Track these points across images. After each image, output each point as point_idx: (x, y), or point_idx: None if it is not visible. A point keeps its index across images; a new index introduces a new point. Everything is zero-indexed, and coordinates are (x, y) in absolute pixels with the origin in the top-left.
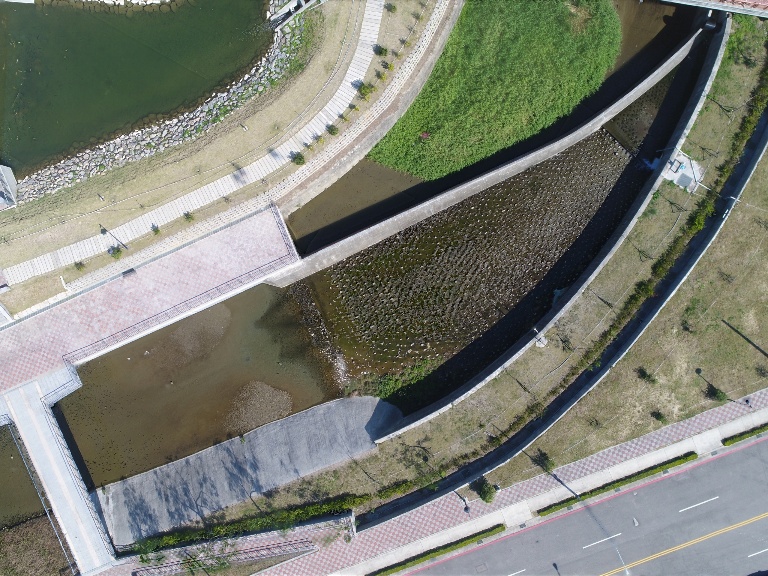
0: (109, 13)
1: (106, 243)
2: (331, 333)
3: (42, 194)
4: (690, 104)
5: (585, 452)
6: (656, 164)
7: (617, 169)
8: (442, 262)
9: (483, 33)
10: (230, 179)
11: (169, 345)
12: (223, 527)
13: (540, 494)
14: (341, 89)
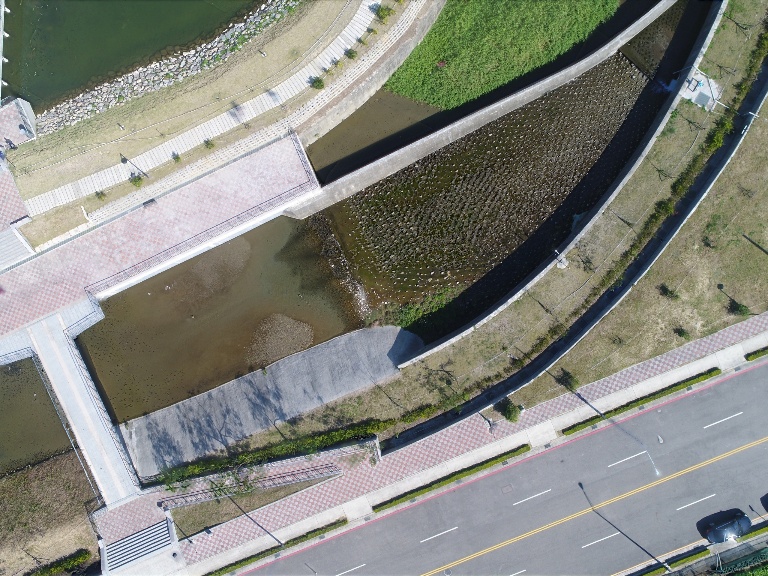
0: None
1: (127, 172)
2: (351, 264)
3: (62, 126)
4: (706, 25)
5: (609, 370)
6: (673, 85)
7: (634, 92)
8: (461, 190)
9: None
10: (249, 105)
11: (189, 279)
12: (248, 455)
13: (564, 413)
14: (359, 13)
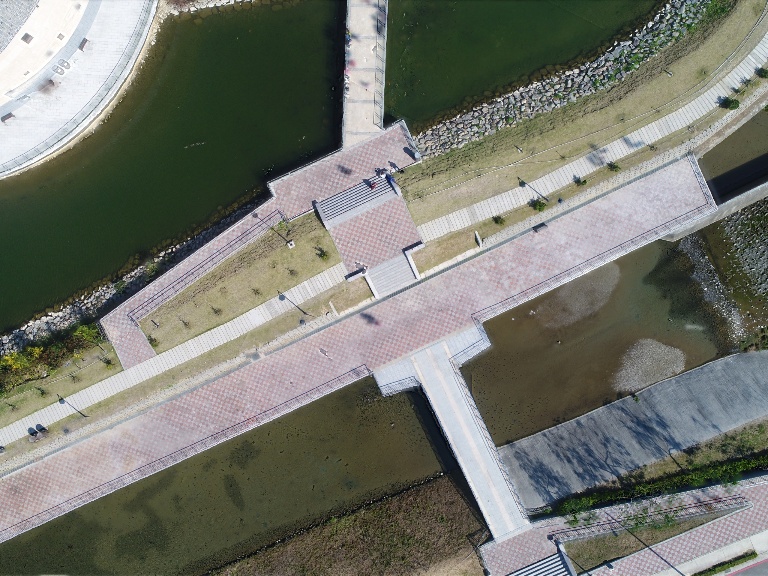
0: None
1: (525, 196)
2: (725, 287)
3: (448, 149)
4: None
5: None
6: None
7: None
8: None
9: None
10: (655, 127)
11: (555, 304)
12: (646, 486)
13: None
14: None
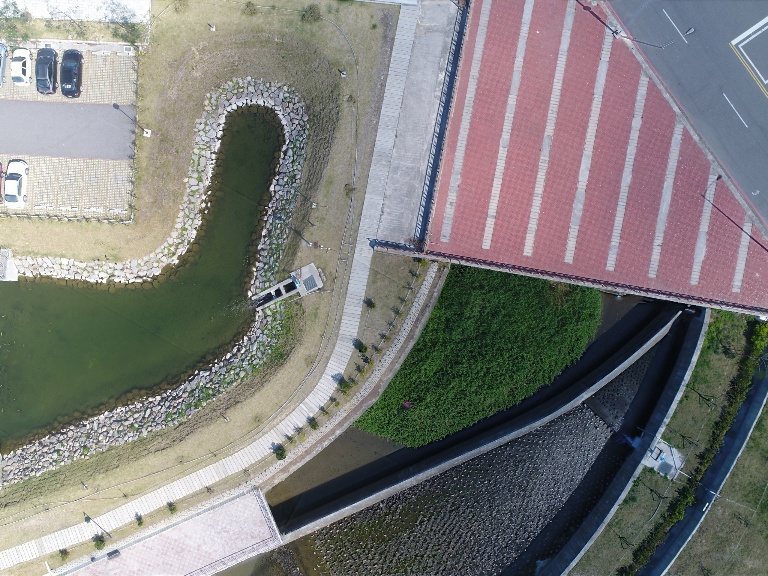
0: (92, 289)
1: (90, 531)
2: None
3: (27, 476)
4: (670, 385)
5: None
6: (637, 444)
7: (598, 443)
8: (425, 531)
9: (464, 309)
10: (212, 469)
11: None
12: None
13: None
14: (322, 382)
